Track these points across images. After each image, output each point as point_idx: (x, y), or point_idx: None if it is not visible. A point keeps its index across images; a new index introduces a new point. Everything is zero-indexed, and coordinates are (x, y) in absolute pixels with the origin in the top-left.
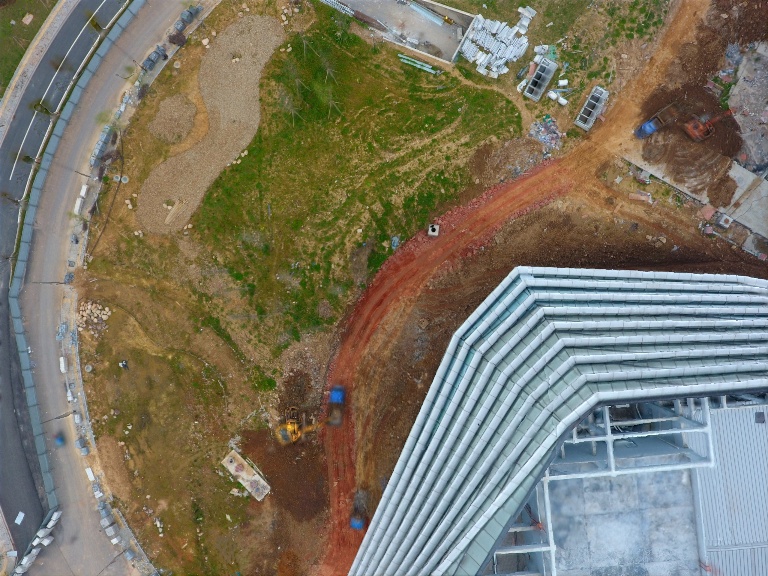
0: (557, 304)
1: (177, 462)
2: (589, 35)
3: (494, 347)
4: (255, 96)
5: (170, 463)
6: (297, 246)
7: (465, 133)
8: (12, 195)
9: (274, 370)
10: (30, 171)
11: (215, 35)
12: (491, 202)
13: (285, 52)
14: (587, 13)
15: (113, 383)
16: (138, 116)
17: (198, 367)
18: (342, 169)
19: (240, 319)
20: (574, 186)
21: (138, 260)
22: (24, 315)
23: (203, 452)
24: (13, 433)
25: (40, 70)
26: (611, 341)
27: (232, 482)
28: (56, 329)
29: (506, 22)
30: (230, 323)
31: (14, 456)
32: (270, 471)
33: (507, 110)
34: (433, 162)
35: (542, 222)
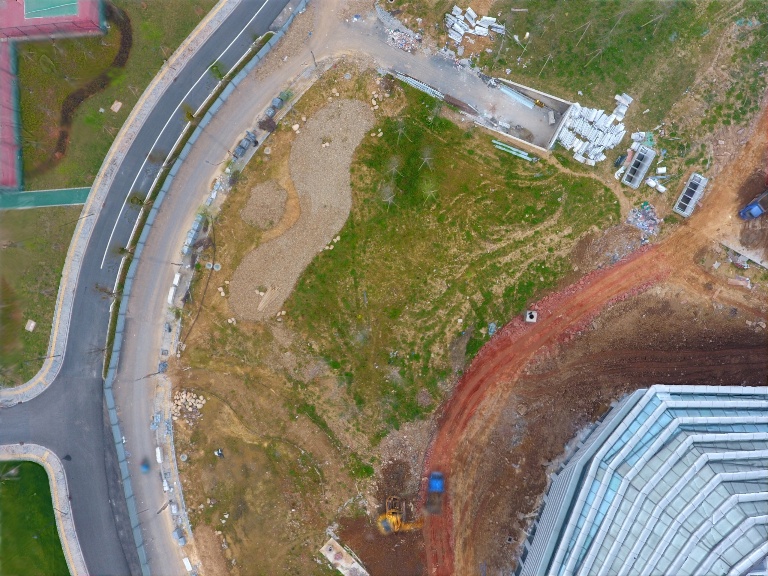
0: (701, 427)
1: (275, 550)
2: (686, 122)
3: (641, 473)
4: (346, 181)
5: (268, 551)
6: (395, 335)
7: (567, 224)
8: (104, 284)
9: (372, 458)
10: (121, 259)
11: (305, 120)
12: (588, 288)
13: (376, 137)
14: (683, 100)
15: (209, 472)
16: (229, 203)
17: (294, 454)
18: (440, 258)
19: (338, 408)
20: (672, 272)
21: (232, 348)
22: (118, 405)
23: (301, 540)
24: (109, 524)
25: (129, 157)
26: (767, 474)
27: (330, 570)
28: (150, 418)
29: (603, 110)
30: (327, 411)
31: (110, 547)
32: (368, 558)
33: (605, 198)
34: (535, 253)
35: (641, 308)
